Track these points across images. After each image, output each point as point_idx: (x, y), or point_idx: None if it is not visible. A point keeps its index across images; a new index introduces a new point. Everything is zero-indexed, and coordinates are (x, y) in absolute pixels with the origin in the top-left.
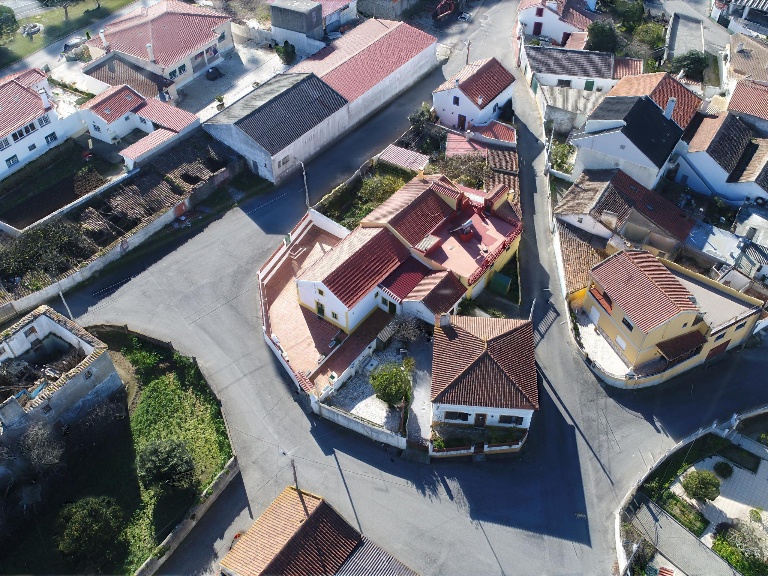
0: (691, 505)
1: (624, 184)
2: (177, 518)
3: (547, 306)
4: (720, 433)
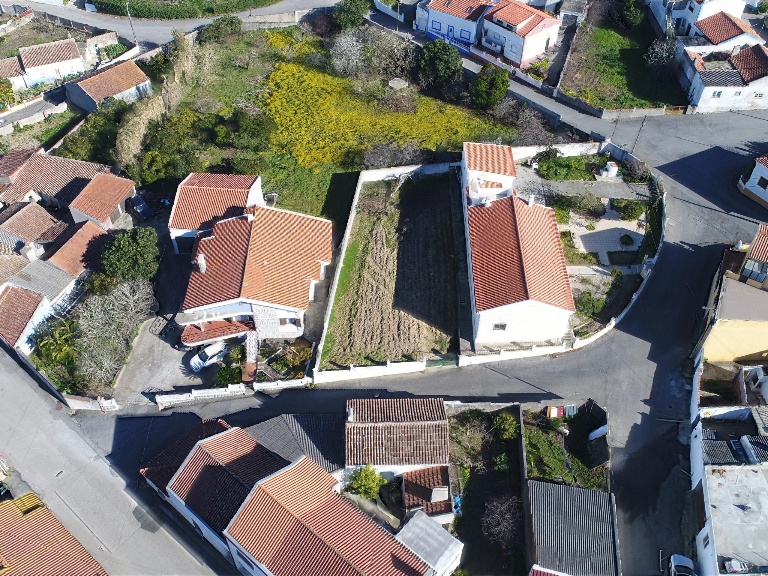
0: None
1: None
2: None
3: None
4: None
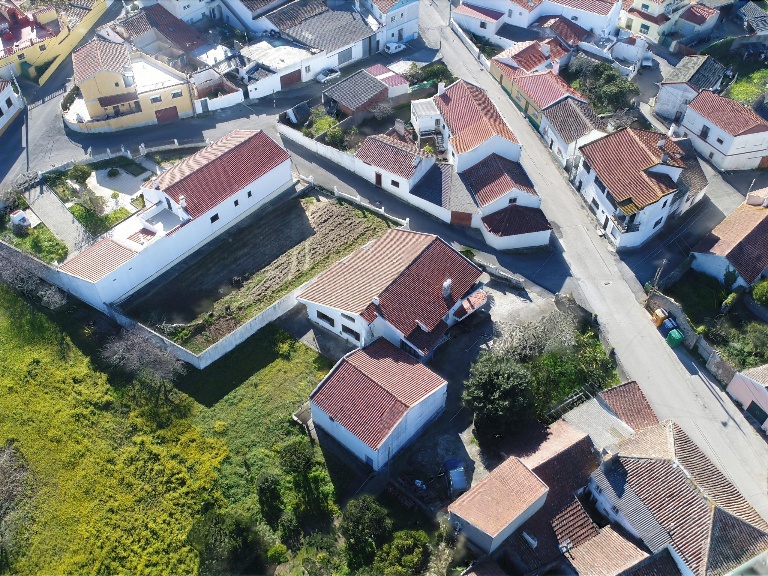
0: (74, 188)
1: (157, 13)
2: None
3: (61, 87)
4: (127, 155)
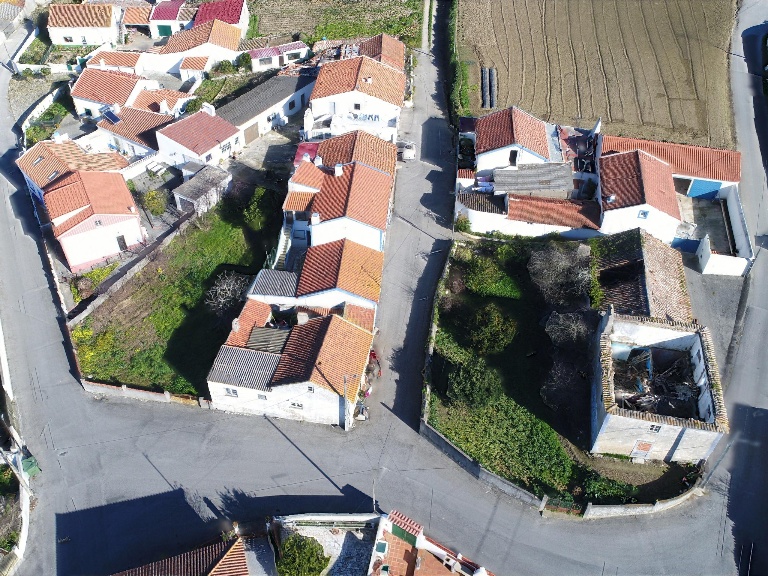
0: None
1: None
2: (441, 375)
3: None
4: None
